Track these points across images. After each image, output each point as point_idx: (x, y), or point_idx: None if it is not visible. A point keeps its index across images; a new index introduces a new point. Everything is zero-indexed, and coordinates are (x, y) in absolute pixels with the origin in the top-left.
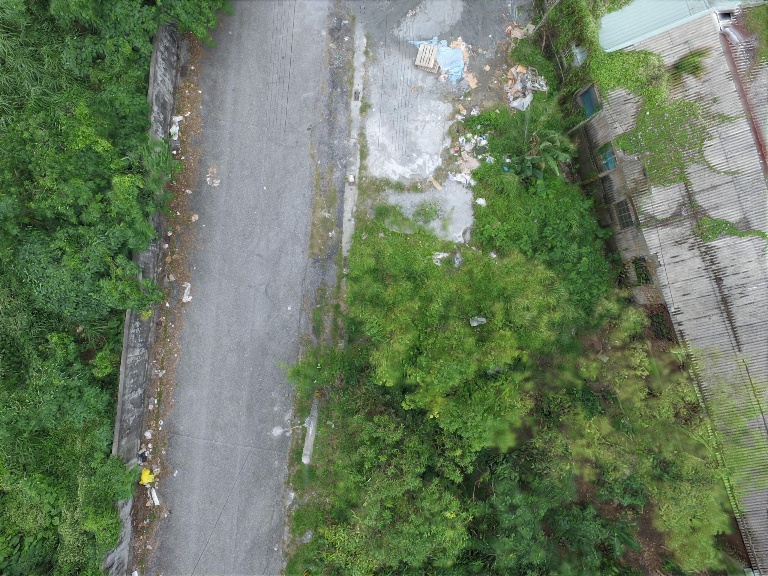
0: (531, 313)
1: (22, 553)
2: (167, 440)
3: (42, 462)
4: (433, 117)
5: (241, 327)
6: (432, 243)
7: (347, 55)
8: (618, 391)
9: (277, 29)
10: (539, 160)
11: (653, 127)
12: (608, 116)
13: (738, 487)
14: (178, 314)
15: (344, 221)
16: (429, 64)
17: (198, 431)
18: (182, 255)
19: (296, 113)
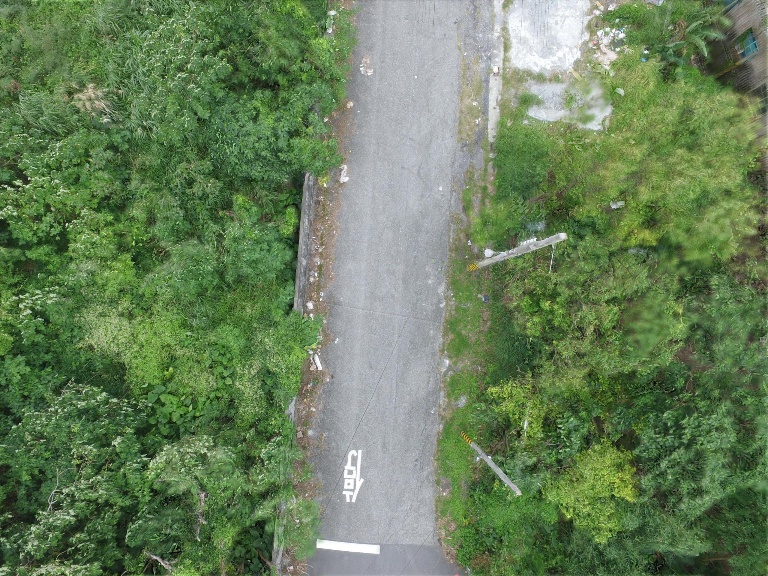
0: (672, 193)
1: (196, 411)
2: (328, 310)
3: (214, 326)
4: (572, 12)
5: (396, 206)
6: (574, 130)
7: None
8: (749, 275)
9: None
10: (682, 46)
11: None
12: None
13: None
14: (335, 194)
15: (489, 109)
16: None
17: (357, 302)
18: (338, 139)
19: (443, 8)
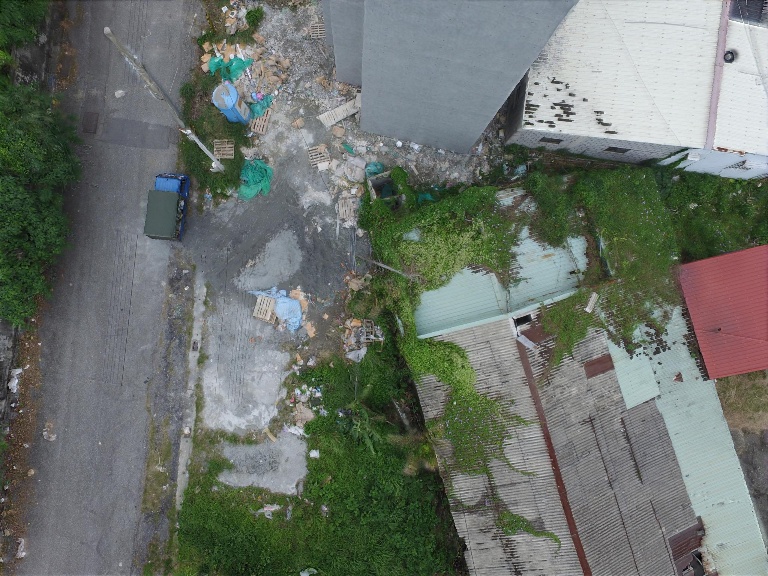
0: (356, 572)
1: None
2: None
3: None
4: (270, 367)
5: None
6: (265, 496)
7: (187, 305)
8: None
9: (117, 281)
10: None
11: (459, 418)
12: (420, 399)
13: None
14: (11, 570)
15: (179, 474)
16: (266, 316)
17: None
18: (17, 510)
19: (133, 366)
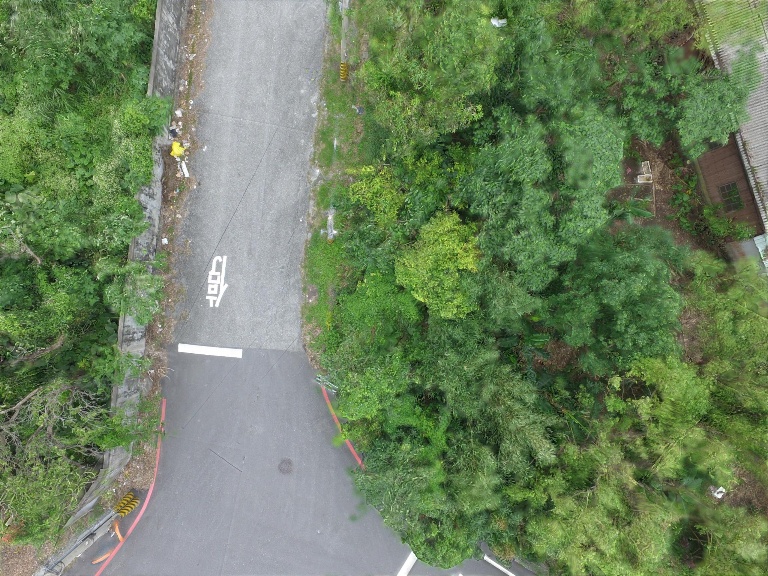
0: (551, 6)
1: None
2: (197, 118)
3: (77, 128)
4: None
5: (269, 14)
6: None
7: None
8: None
9: None
10: None
11: None
12: None
13: (750, 143)
14: (208, 2)
15: None
16: None
17: (227, 110)
18: None
19: None
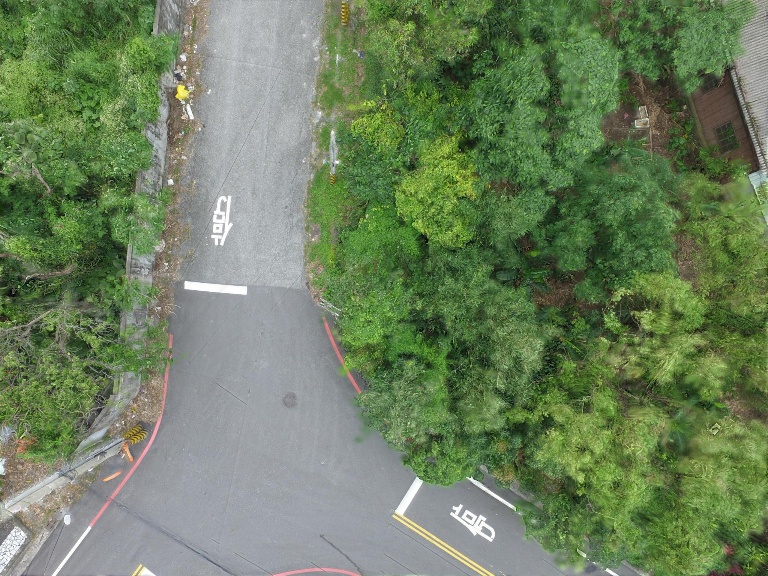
0: None
1: None
2: (201, 62)
3: (84, 71)
4: None
5: None
6: None
7: None
8: None
9: None
10: None
11: None
12: None
13: (745, 79)
14: None
15: None
16: None
17: (231, 53)
18: None
19: None
